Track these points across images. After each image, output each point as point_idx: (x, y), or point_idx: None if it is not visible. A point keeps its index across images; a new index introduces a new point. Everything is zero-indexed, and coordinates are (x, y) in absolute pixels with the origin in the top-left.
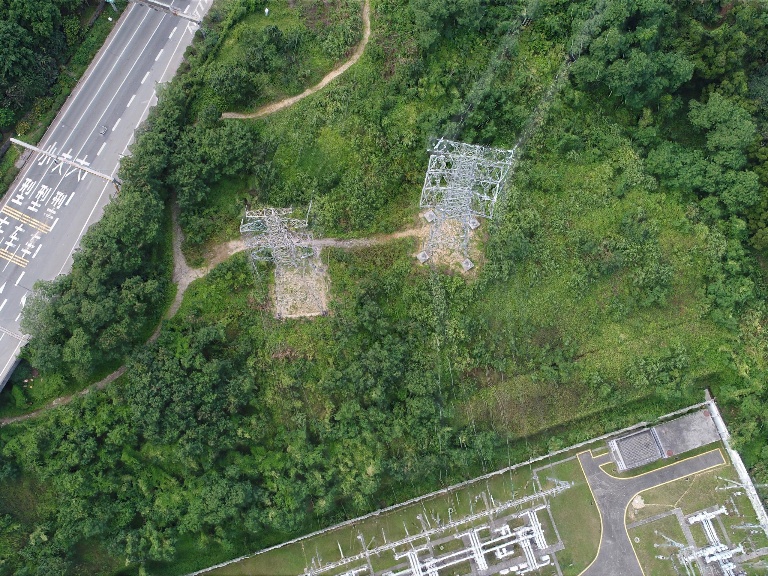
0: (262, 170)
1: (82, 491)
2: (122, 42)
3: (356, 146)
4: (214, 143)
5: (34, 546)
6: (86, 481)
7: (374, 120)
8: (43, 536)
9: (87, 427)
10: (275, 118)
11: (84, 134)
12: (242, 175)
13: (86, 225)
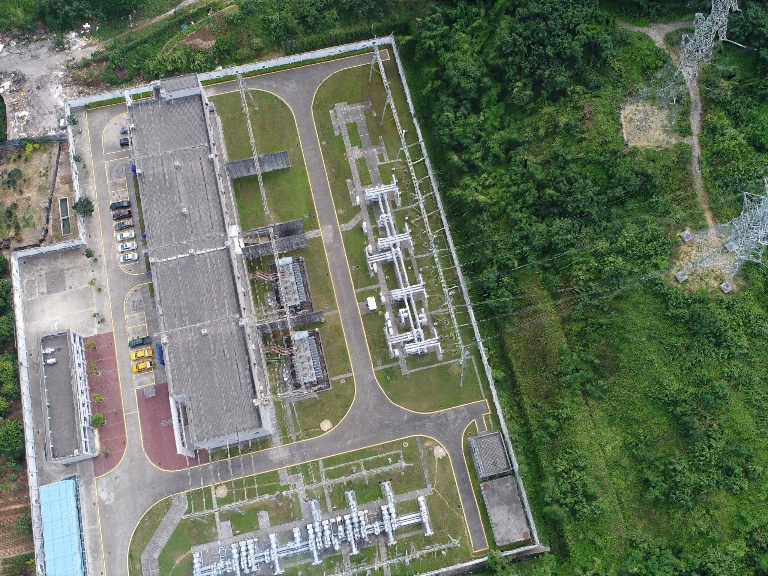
0: (767, 81)
1: None
2: None
3: None
4: None
5: None
6: None
7: None
8: None
9: None
10: None
11: None
12: (760, 67)
13: None
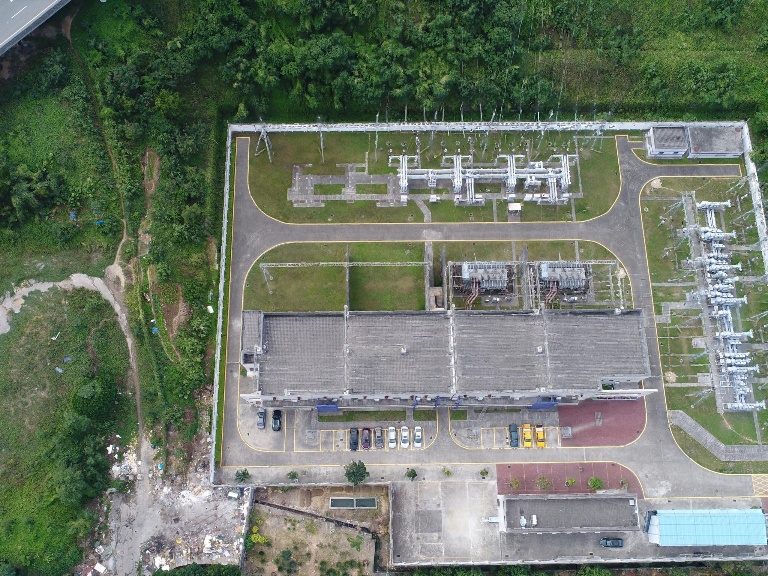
0: None
1: (220, 7)
2: None
3: None
4: None
5: (169, 50)
6: None
7: None
8: (178, 43)
9: None
10: None
11: None
12: None
13: None
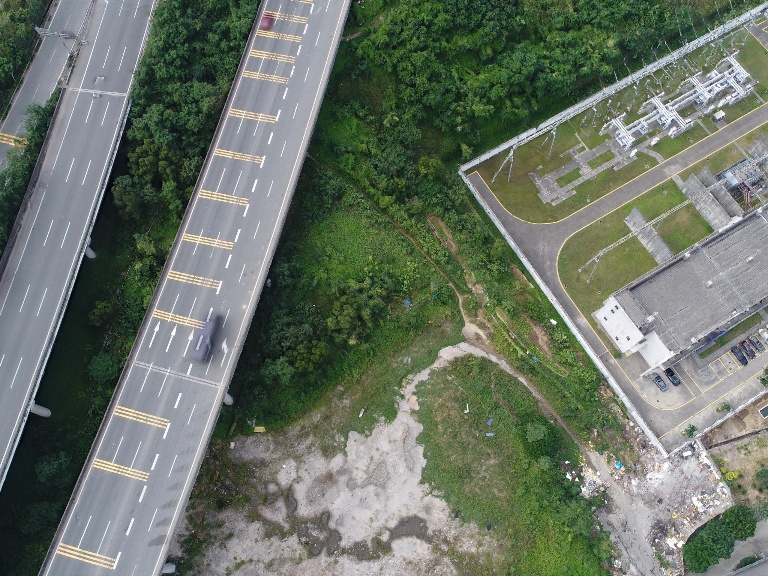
0: None
1: (423, 68)
2: None
3: None
4: None
5: (390, 127)
6: (425, 59)
7: None
8: (396, 117)
9: (418, 18)
10: None
11: None
12: None
13: None
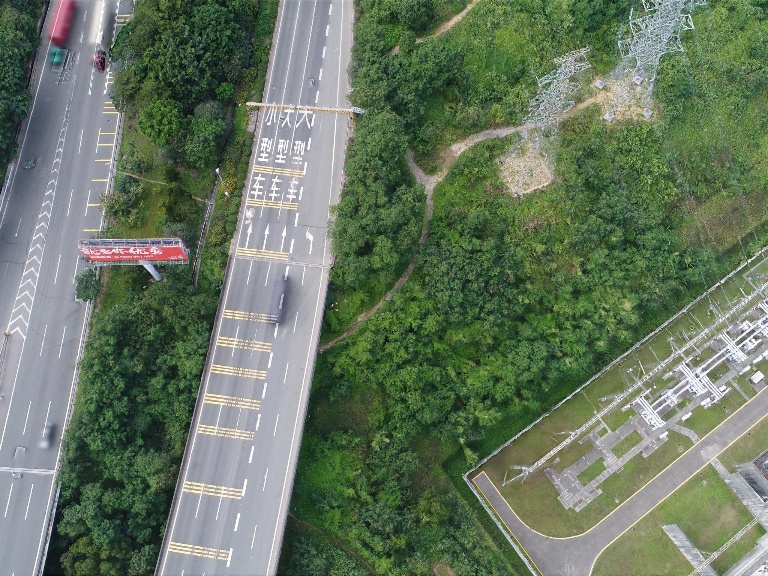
0: (462, 77)
1: (415, 383)
2: (293, 8)
3: (530, 37)
4: (423, 60)
5: (380, 451)
6: (417, 373)
7: (539, 11)
8: (386, 439)
9: (404, 325)
10: (453, 33)
11: (296, 89)
12: (445, 86)
13: (334, 161)
